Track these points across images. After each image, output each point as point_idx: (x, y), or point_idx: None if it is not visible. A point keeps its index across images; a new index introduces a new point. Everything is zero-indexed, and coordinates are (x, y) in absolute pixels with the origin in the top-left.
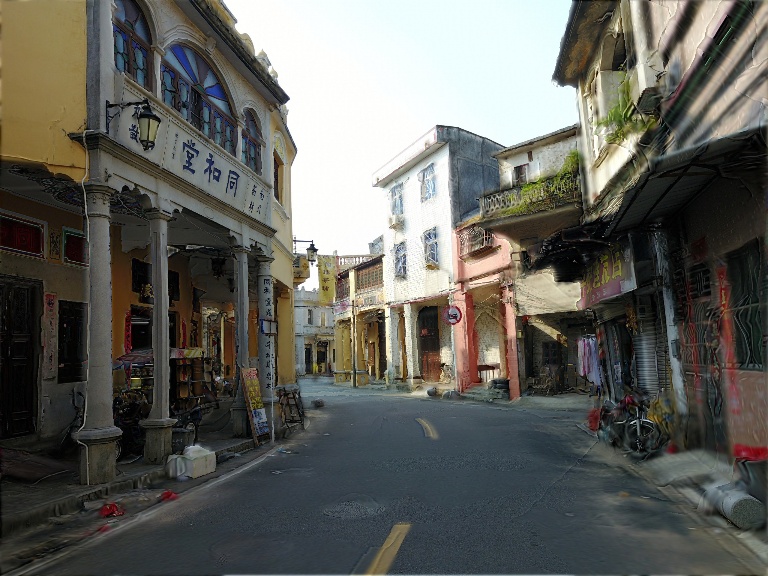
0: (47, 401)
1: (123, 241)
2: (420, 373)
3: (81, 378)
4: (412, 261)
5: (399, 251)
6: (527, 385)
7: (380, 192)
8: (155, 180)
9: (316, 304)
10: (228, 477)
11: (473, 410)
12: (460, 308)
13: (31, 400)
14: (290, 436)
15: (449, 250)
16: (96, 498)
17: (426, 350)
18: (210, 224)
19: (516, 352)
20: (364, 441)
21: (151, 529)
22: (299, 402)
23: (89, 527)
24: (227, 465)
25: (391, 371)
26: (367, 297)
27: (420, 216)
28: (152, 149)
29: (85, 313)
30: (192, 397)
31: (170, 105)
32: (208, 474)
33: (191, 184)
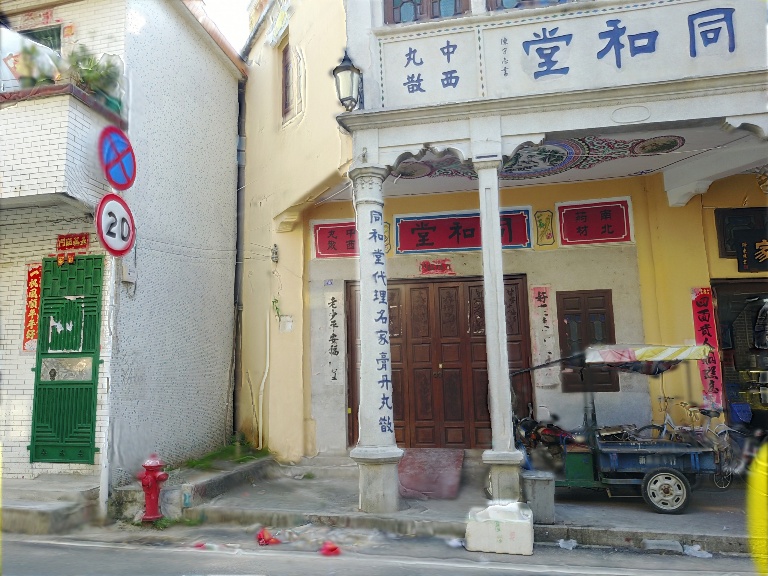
0: (546, 412)
1: (669, 192)
2: None
3: (605, 387)
4: None
5: None
6: None
7: None
8: (467, 122)
9: None
10: (483, 567)
11: None
12: None
13: (528, 410)
14: None
15: None
16: (331, 524)
17: None
18: (664, 128)
19: None
20: None
21: (180, 563)
22: None
23: (222, 542)
24: (592, 557)
25: None
26: None
27: None
28: (456, 86)
29: (607, 302)
30: None
31: (514, 2)
32: (504, 554)
33: (545, 94)
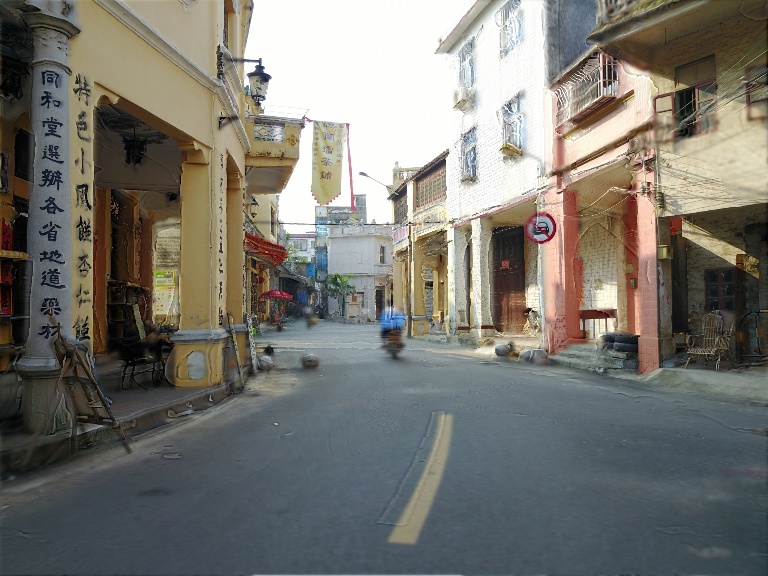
0: None
1: None
2: (497, 321)
3: None
4: (484, 154)
5: (467, 142)
6: (674, 347)
7: (444, 61)
8: None
9: (390, 240)
10: None
11: (566, 393)
12: (554, 216)
13: None
14: (63, 461)
15: (539, 124)
16: None
17: (506, 290)
18: None
19: (655, 285)
20: (157, 529)
21: None
22: (233, 362)
23: None
24: None
25: (453, 317)
26: (427, 216)
27: (497, 81)
28: None
29: None
30: (1, 347)
31: None
32: None
33: None
